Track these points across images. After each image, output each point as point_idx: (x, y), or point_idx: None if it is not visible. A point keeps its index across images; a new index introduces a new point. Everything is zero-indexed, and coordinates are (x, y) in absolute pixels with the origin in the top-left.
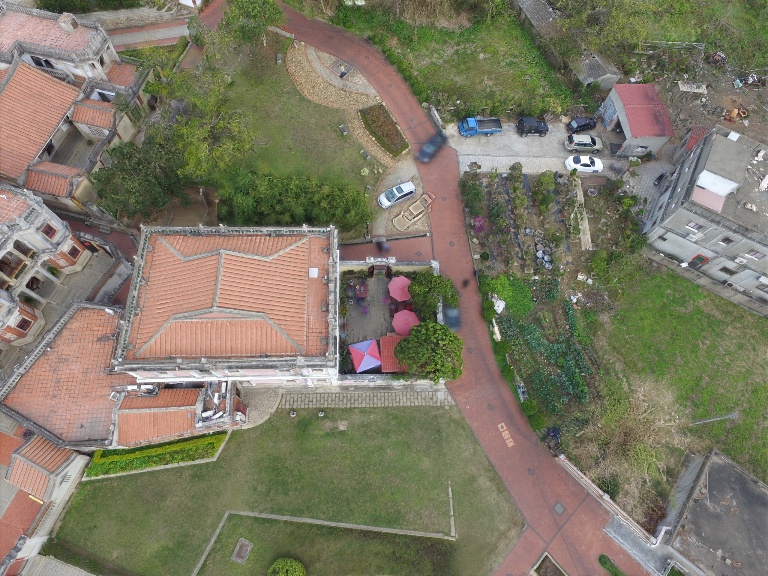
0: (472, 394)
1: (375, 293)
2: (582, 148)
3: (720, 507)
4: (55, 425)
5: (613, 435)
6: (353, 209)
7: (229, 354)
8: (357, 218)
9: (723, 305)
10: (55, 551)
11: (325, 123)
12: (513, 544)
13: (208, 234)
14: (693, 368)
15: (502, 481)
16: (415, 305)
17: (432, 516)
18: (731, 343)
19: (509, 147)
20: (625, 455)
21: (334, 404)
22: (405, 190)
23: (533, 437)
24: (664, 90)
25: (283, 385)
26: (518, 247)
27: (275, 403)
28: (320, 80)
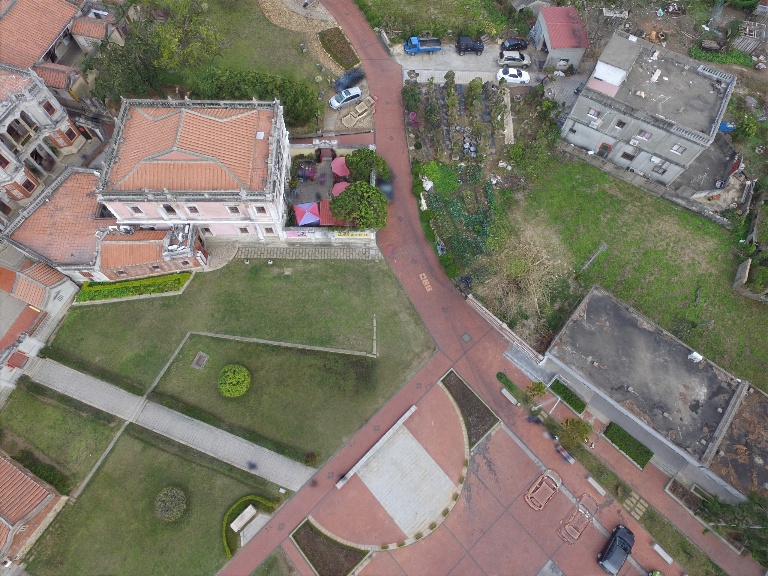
0: (399, 251)
1: (322, 175)
2: (512, 63)
3: (594, 326)
4: (51, 254)
5: (503, 263)
6: (301, 99)
7: (187, 190)
8: (306, 109)
9: (626, 188)
10: (49, 353)
11: (288, 43)
12: (425, 362)
13: (176, 107)
14: (593, 235)
15: (419, 316)
16: (351, 176)
17: (358, 339)
18: (629, 217)
19: (448, 63)
20: (519, 288)
21: (282, 256)
22: (352, 93)
23: (449, 284)
24: (592, 18)
25: (239, 239)
26: (449, 141)
27: (232, 253)
28: (286, 9)
